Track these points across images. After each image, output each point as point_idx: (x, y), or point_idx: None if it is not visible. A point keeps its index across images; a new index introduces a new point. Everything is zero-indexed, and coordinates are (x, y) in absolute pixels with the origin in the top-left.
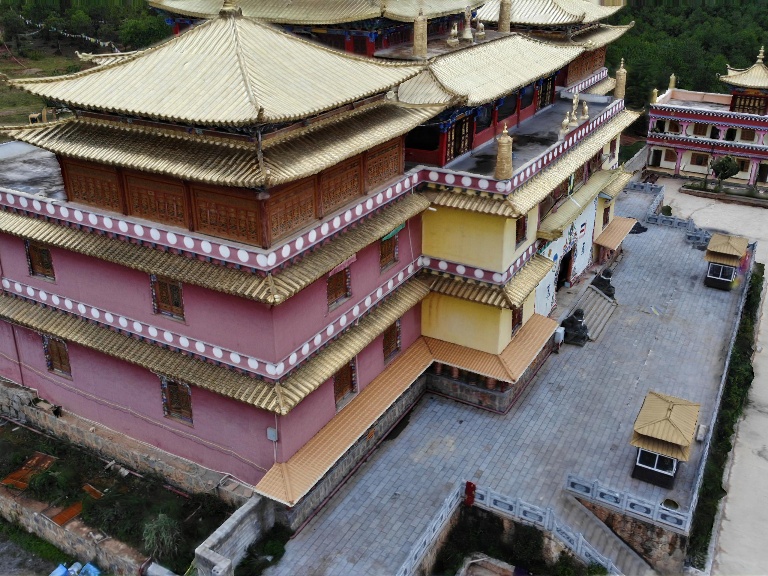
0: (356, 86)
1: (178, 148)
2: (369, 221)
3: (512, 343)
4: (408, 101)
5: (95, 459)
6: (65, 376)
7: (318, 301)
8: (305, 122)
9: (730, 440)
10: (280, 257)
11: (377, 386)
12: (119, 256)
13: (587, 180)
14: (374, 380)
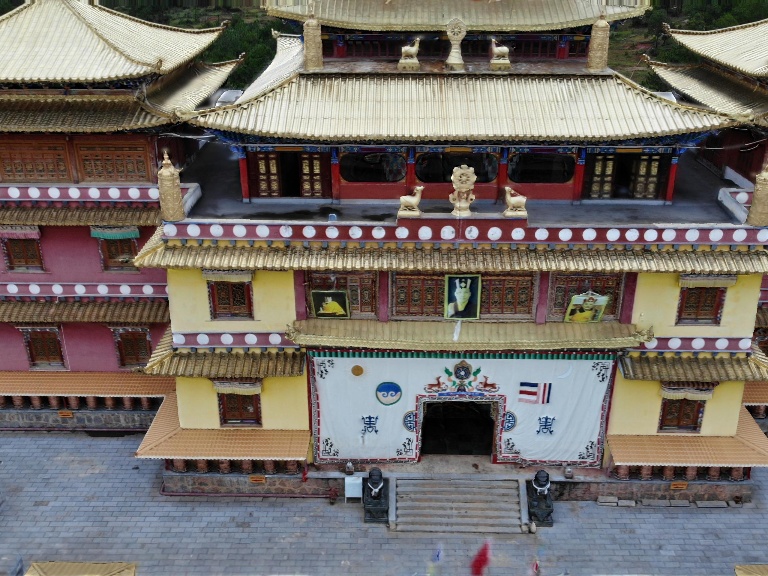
0: (50, 70)
1: None
2: (66, 208)
3: (216, 431)
4: None
5: None
6: None
7: None
8: None
9: None
10: None
11: (90, 377)
12: None
13: (558, 321)
14: (98, 372)
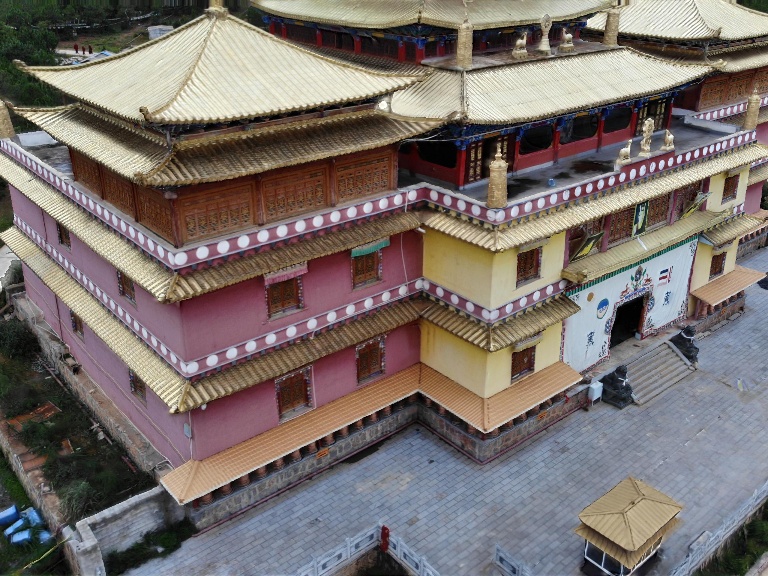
0: (320, 93)
1: (125, 141)
2: (331, 234)
3: (510, 389)
4: (425, 113)
5: (85, 419)
6: (82, 338)
7: (252, 307)
8: (246, 126)
9: (759, 559)
10: (194, 258)
11: (339, 405)
12: (87, 236)
13: (676, 220)
14: (340, 398)
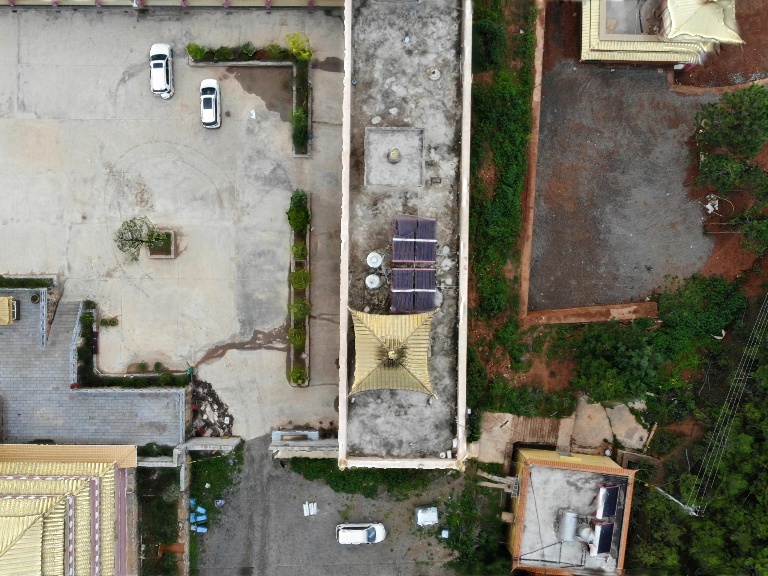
0: None
1: (43, 572)
2: None
3: None
4: None
5: (144, 567)
6: None
7: None
8: None
9: None
10: None
11: (37, 458)
12: None
13: None
14: None
